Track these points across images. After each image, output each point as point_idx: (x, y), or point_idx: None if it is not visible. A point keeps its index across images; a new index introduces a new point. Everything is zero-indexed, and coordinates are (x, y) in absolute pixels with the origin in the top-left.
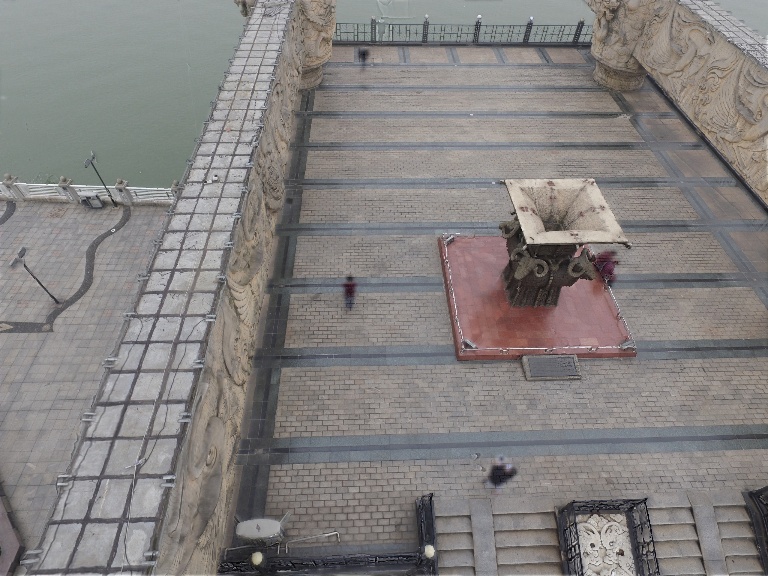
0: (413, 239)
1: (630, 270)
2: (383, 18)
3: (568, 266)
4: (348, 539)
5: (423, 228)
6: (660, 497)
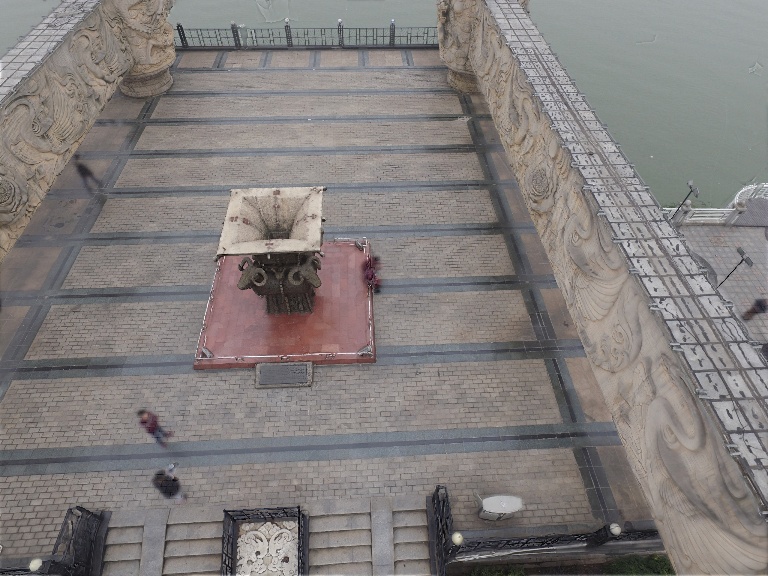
0: (198, 247)
1: (405, 275)
2: (244, 23)
3: (288, 274)
4: (10, 552)
5: (213, 236)
6: (342, 503)
